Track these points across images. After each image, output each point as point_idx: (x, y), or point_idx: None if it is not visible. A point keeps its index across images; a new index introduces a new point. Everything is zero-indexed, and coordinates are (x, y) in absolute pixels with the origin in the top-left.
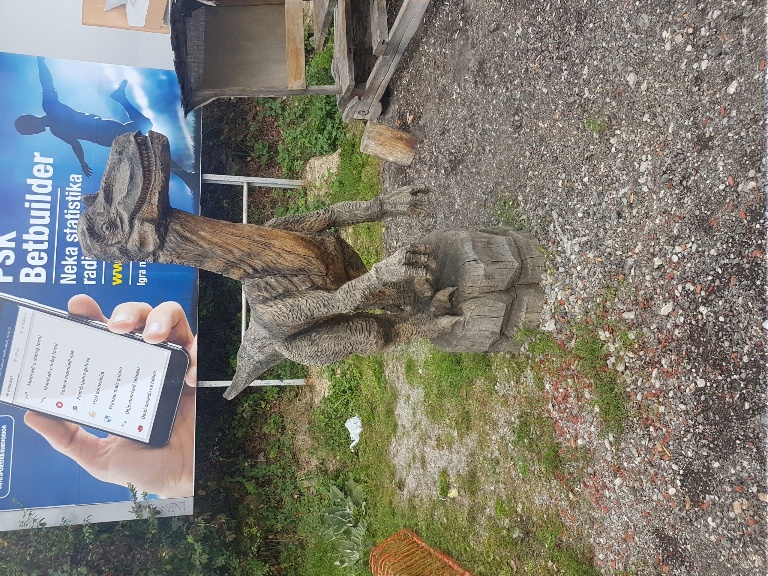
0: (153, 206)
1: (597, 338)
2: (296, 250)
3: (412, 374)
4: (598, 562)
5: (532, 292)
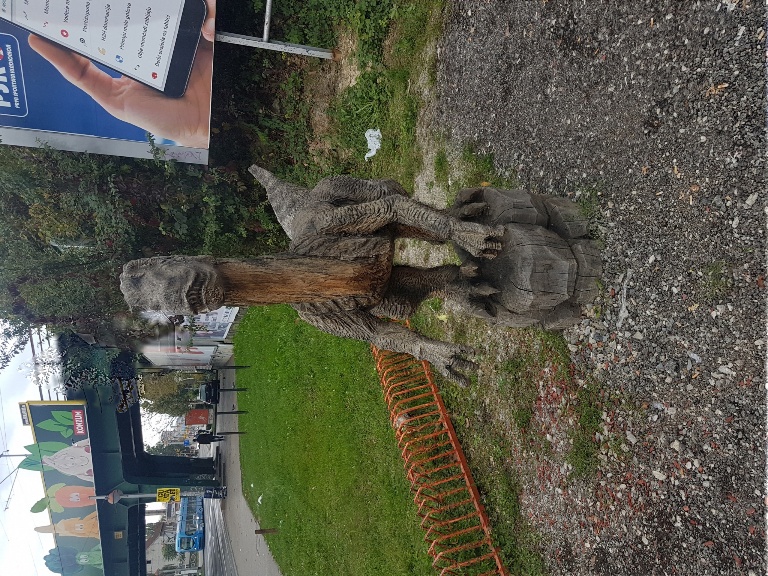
0: None
1: (599, 414)
2: None
3: (441, 172)
4: (522, 500)
5: (570, 316)
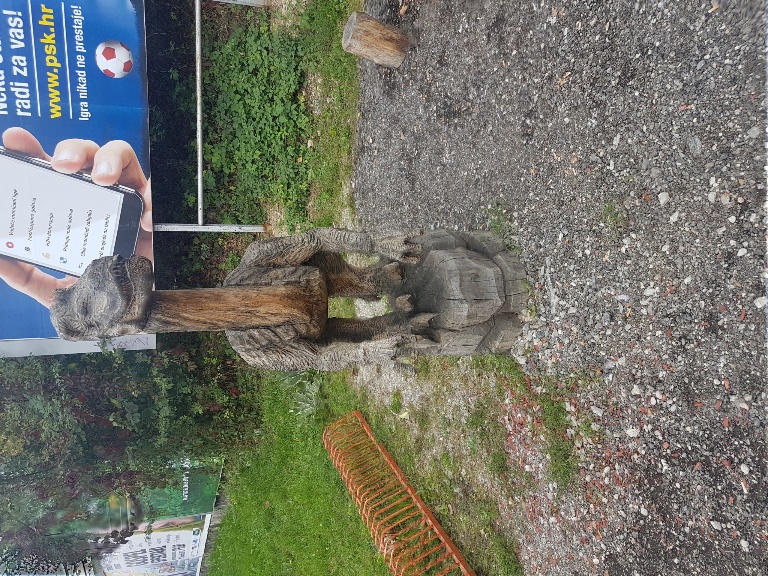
0: (132, 314)
1: (563, 407)
2: (281, 311)
3: None
4: (523, 558)
5: (510, 326)
